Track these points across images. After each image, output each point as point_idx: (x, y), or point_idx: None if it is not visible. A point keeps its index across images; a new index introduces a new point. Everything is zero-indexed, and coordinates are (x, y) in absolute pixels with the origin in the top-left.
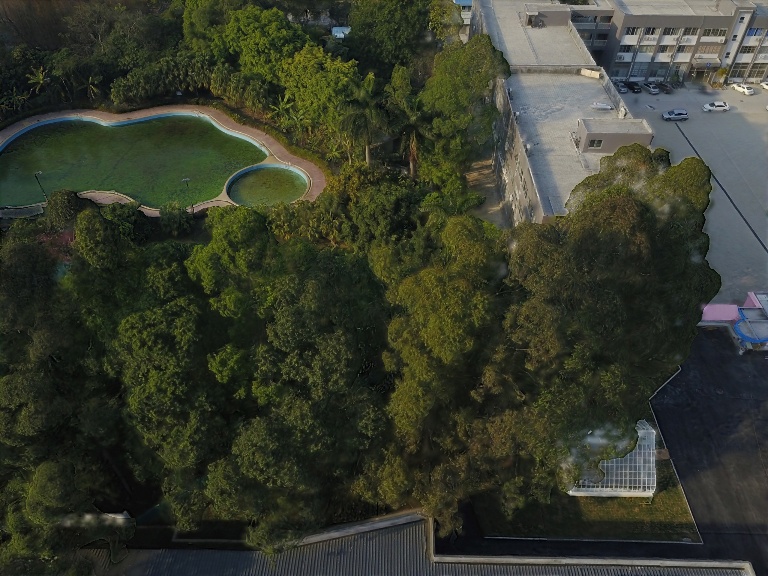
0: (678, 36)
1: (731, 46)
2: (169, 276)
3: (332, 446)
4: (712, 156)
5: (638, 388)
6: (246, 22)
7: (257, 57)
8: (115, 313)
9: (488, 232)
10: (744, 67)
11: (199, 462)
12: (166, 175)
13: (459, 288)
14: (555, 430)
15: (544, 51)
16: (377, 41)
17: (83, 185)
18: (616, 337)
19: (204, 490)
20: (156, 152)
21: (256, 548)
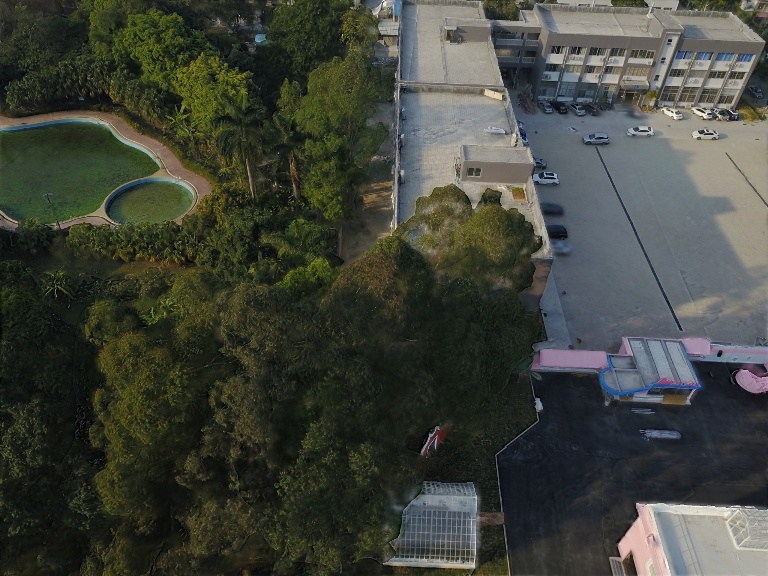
0: (605, 56)
1: (660, 69)
2: None
3: (48, 526)
4: (626, 184)
5: (400, 468)
6: (141, 27)
7: (152, 64)
8: None
9: (320, 270)
10: (675, 91)
11: None
12: (48, 186)
13: (154, 360)
14: (287, 519)
15: (456, 68)
16: (288, 51)
17: None
18: (364, 414)
19: None
20: (44, 161)
21: None
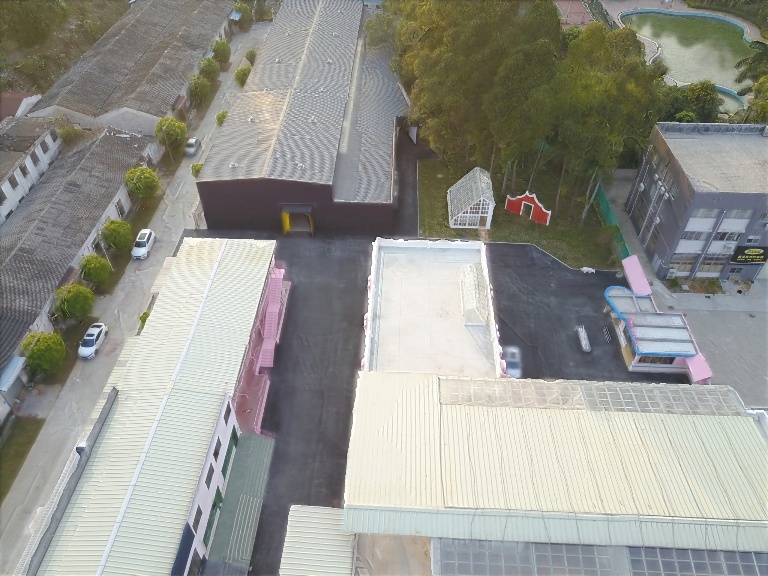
0: None
1: None
2: None
3: None
4: None
5: None
6: None
7: None
8: None
9: None
10: None
11: None
12: None
13: None
14: None
15: None
16: None
17: (665, 43)
18: None
19: None
20: (725, 59)
21: None
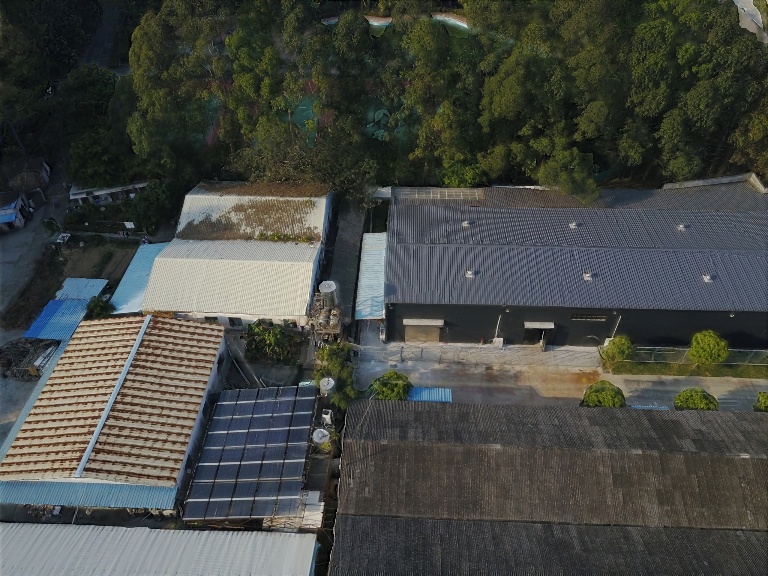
0: None
1: None
2: (656, 7)
3: (726, 109)
4: None
5: None
6: None
7: None
8: (629, 25)
9: None
10: None
11: (660, 112)
12: None
13: None
14: None
15: None
16: None
17: None
18: None
19: (655, 133)
20: None
21: (658, 188)
